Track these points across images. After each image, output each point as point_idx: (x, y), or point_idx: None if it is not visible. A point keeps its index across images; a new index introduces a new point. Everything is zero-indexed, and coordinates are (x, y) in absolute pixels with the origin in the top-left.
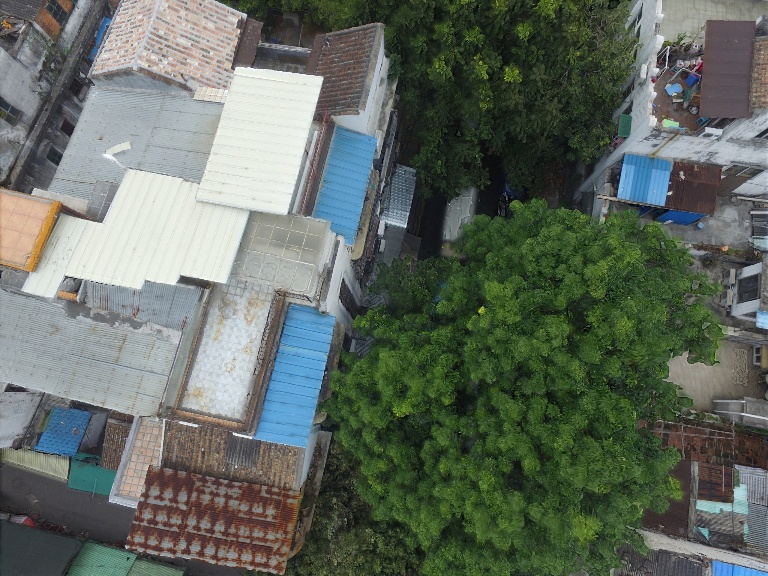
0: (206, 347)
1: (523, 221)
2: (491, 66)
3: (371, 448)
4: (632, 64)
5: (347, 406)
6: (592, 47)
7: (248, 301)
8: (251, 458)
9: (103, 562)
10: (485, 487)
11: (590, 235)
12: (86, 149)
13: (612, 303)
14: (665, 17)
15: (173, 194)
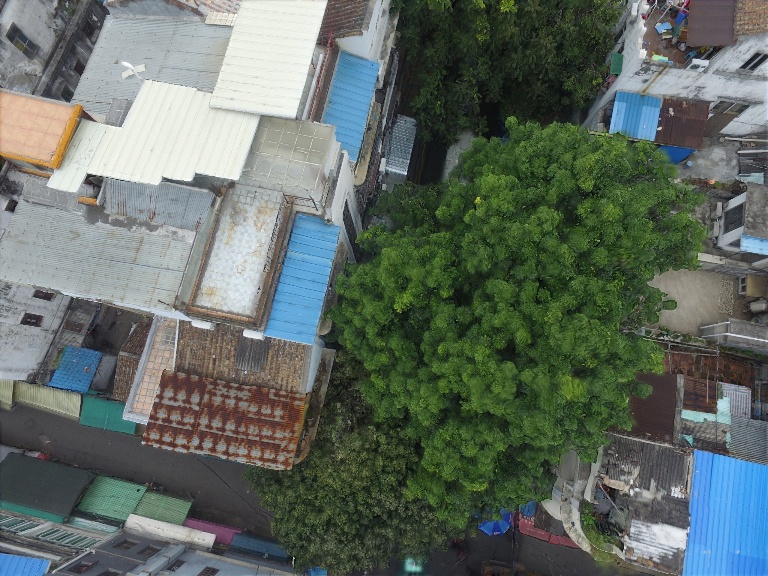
0: (218, 251)
1: (517, 135)
2: None
3: (374, 347)
4: None
5: (351, 308)
6: None
7: (258, 209)
8: (260, 363)
9: (114, 493)
10: (480, 358)
11: (580, 138)
12: (102, 72)
13: (600, 199)
14: None
15: (188, 102)
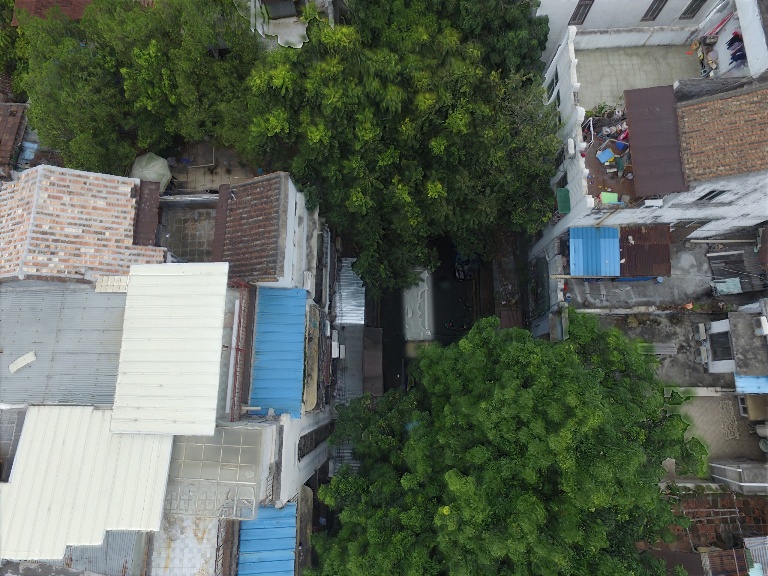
0: None
1: (475, 364)
2: (412, 185)
3: None
4: (558, 130)
5: None
6: (514, 129)
7: None
8: None
9: None
10: None
11: (547, 386)
12: None
13: (585, 460)
14: (582, 79)
15: (84, 428)
